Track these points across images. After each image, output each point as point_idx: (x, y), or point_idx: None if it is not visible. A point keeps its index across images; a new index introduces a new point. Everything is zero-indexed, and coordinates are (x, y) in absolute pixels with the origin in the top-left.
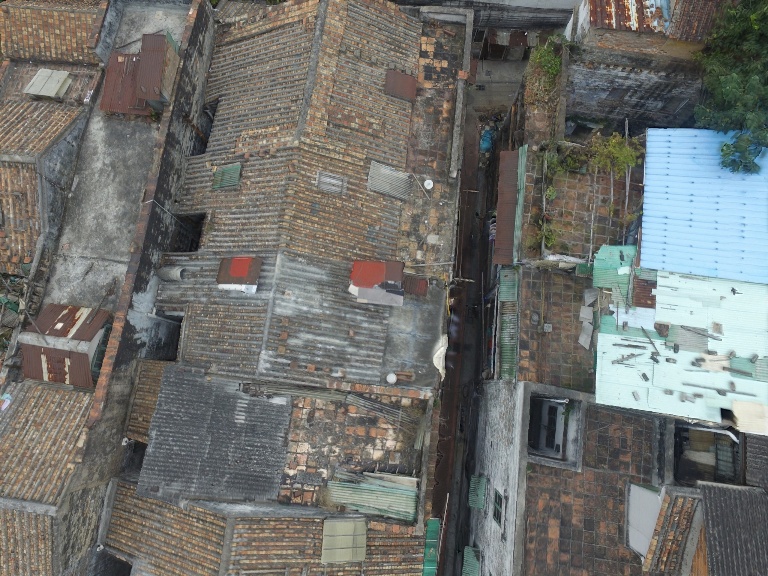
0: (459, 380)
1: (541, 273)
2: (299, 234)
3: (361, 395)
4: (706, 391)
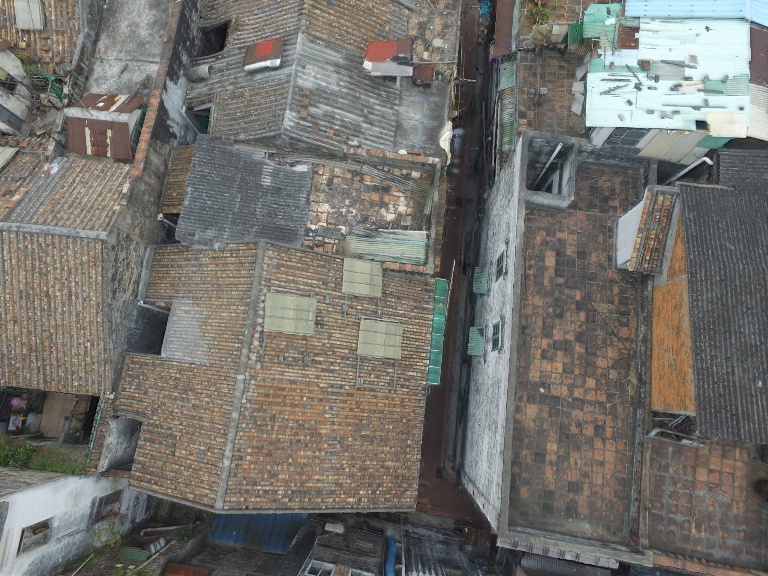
0: (462, 231)
1: (537, 56)
2: (317, 21)
3: (375, 167)
4: (683, 108)
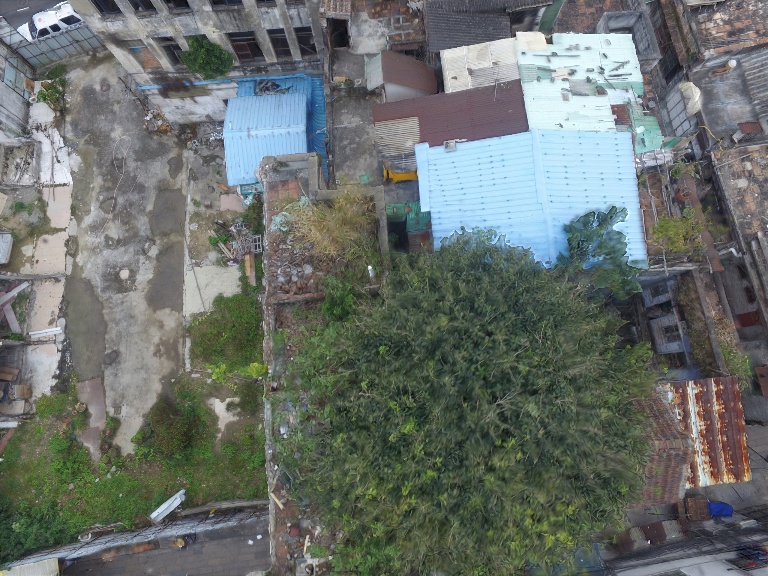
0: None
1: None
2: None
3: None
4: (565, 53)
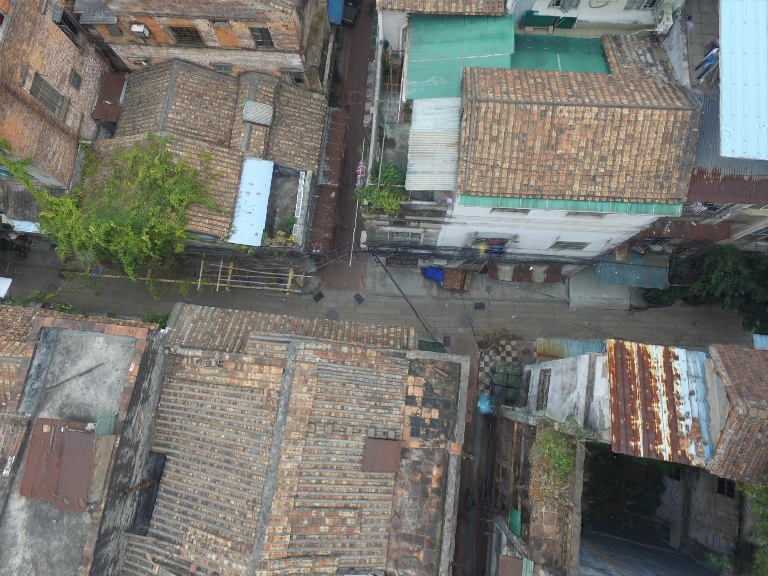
0: None
1: None
2: None
3: None
4: None
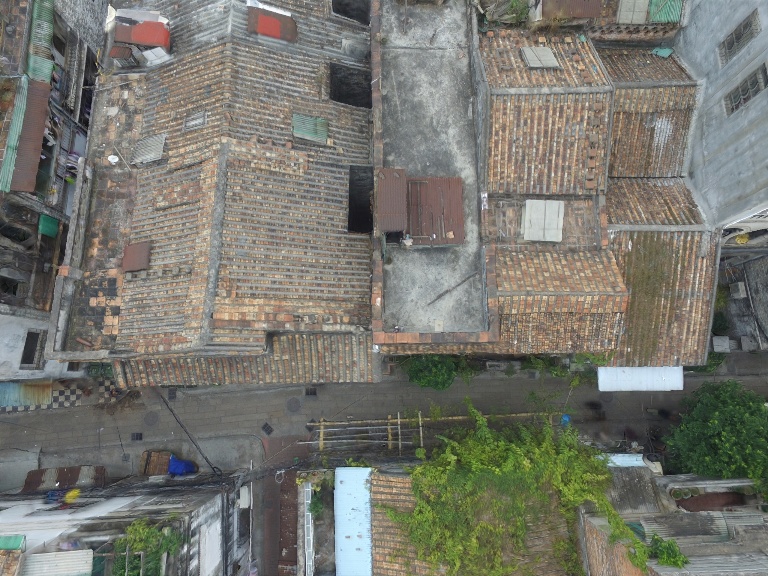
0: None
1: (1, 69)
2: None
3: None
4: None
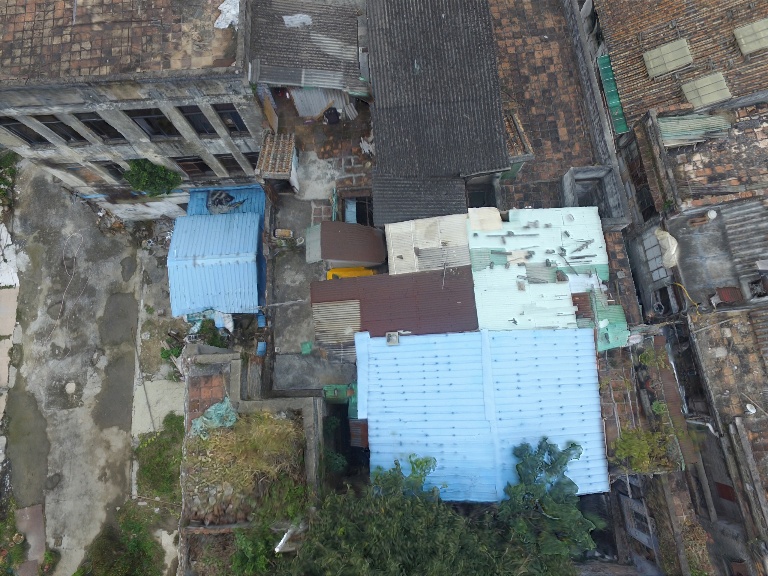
0: None
1: None
2: None
3: None
4: (522, 232)
